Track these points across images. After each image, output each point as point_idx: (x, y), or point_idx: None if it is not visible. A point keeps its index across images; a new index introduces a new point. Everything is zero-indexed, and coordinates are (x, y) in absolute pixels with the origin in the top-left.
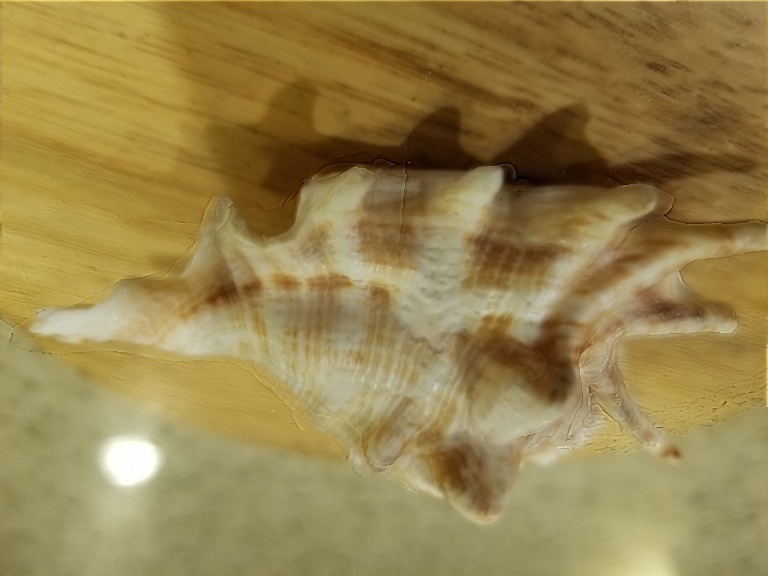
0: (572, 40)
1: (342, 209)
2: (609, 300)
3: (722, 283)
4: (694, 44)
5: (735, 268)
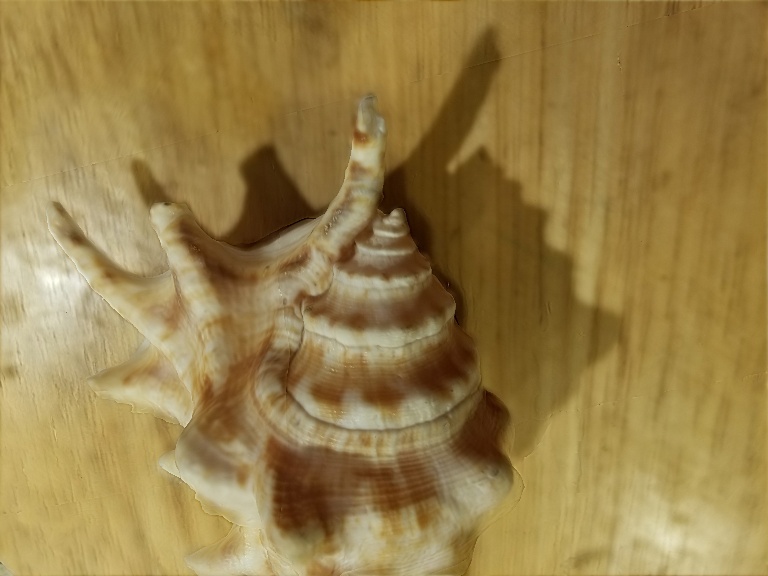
0: (114, 424)
1: (213, 573)
2: (182, 367)
3: (235, 110)
4: (70, 361)
5: (208, 123)
